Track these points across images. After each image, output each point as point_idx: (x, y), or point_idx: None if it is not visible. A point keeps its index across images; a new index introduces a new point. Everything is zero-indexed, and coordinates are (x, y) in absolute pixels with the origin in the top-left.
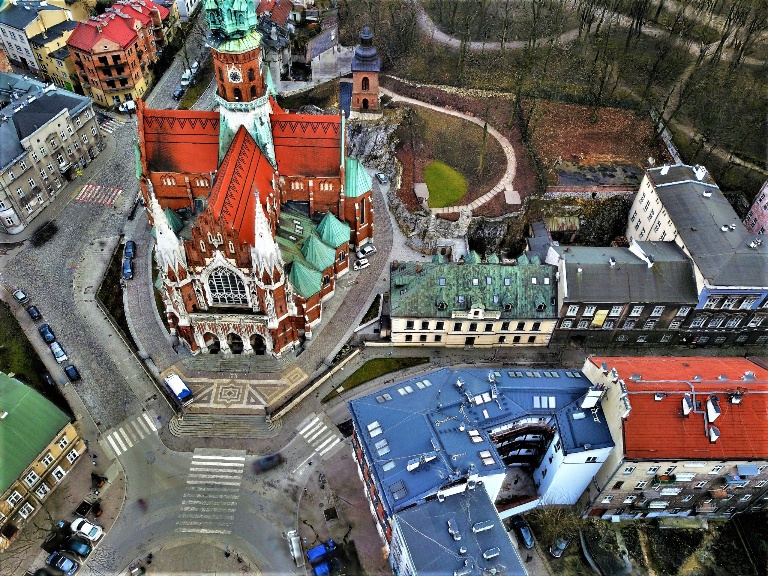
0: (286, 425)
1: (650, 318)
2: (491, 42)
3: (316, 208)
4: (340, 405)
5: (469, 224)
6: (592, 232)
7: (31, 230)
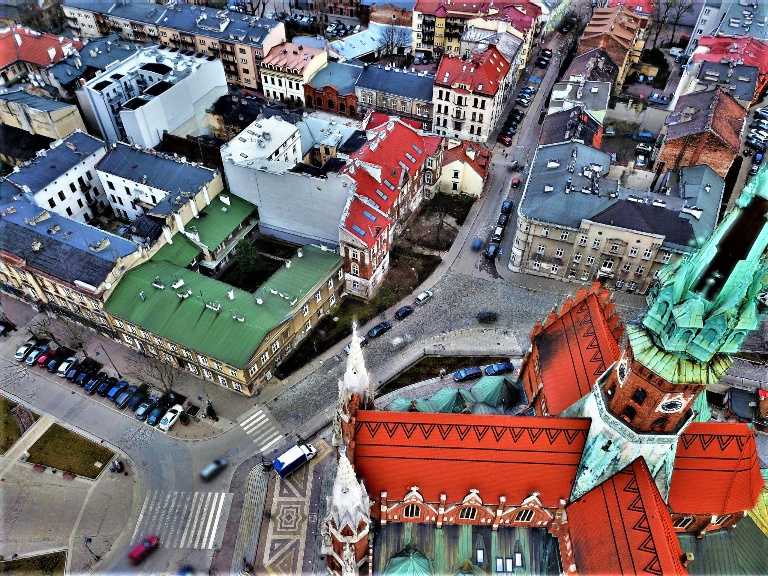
0: None
1: None
2: None
3: None
4: None
5: None
6: None
7: (517, 278)
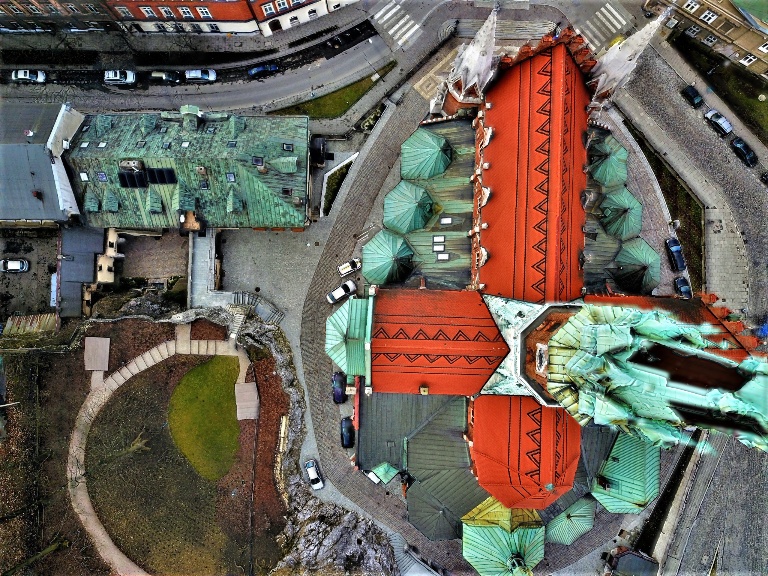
0: (434, 35)
1: None
2: None
3: None
4: (375, 59)
5: None
6: None
7: None
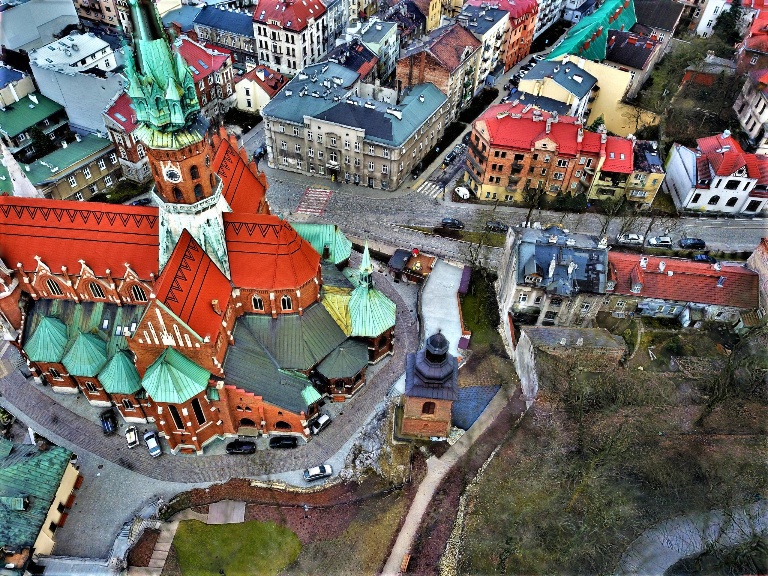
0: None
1: None
2: None
3: None
4: None
5: None
6: None
7: (271, 172)
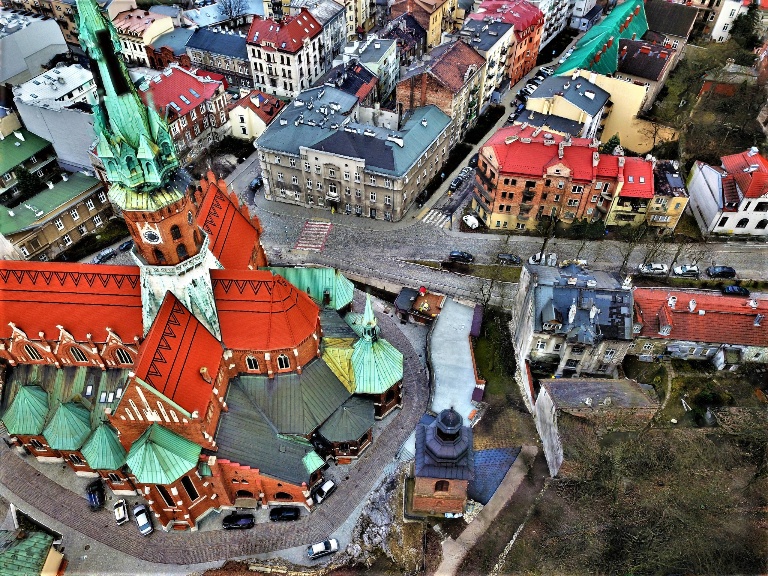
0: None
1: None
2: None
3: None
4: None
5: None
6: None
7: (268, 205)
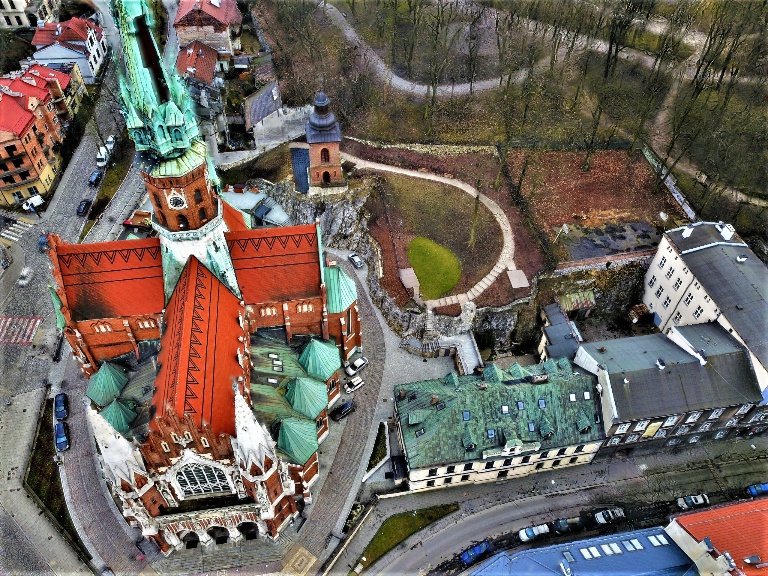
0: None
1: (707, 421)
2: (456, 84)
3: (293, 331)
4: None
5: (473, 317)
6: (608, 304)
7: None
